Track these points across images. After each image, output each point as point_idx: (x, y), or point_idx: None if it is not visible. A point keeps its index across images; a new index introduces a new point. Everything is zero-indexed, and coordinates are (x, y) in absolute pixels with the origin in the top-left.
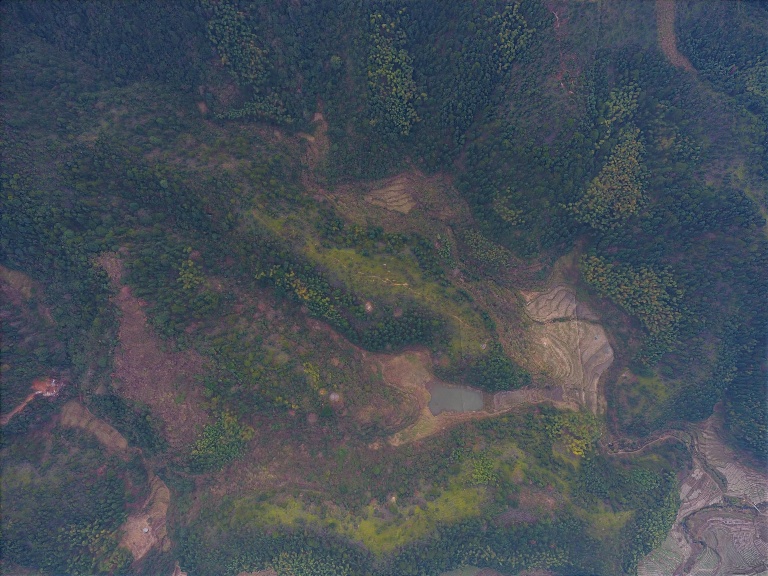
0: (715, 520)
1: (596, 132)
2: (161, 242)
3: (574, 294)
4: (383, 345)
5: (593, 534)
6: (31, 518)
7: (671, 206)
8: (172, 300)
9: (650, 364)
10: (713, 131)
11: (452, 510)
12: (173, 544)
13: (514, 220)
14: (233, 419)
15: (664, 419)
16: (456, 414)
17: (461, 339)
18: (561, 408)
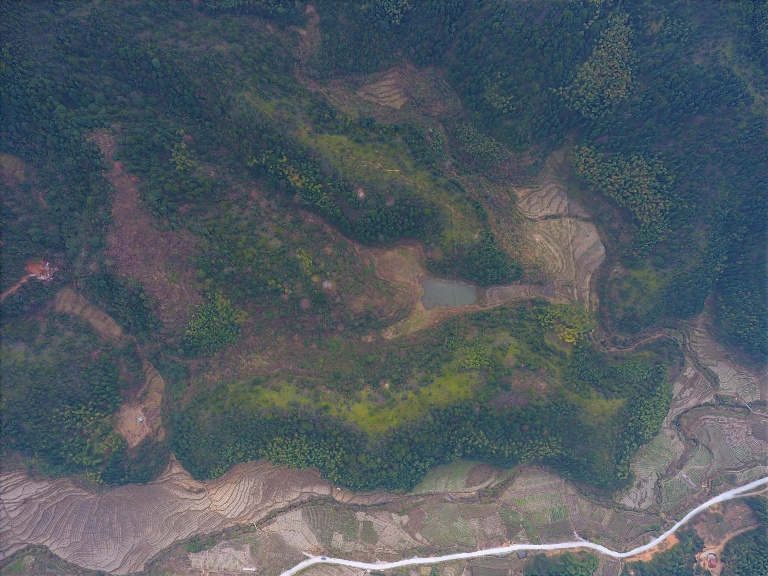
0: (707, 418)
1: (585, 10)
2: (154, 123)
3: (566, 191)
4: (376, 235)
5: (585, 420)
6: (25, 396)
7: (660, 87)
8: (165, 179)
9: (641, 256)
10: (701, 12)
11: (445, 394)
12: (168, 434)
13: (505, 107)
14: (226, 301)
15: (656, 314)
16: (449, 308)
17: (453, 228)
18: (553, 303)
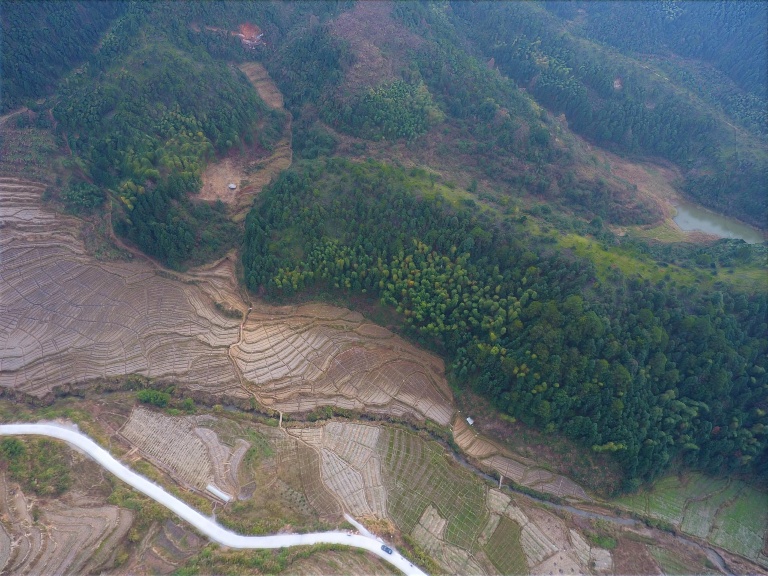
0: None
1: None
2: None
3: None
4: (624, 129)
5: None
6: (149, 78)
7: None
8: None
9: None
10: None
11: (746, 280)
12: None
13: None
14: None
15: None
16: (720, 237)
17: (736, 145)
18: None
